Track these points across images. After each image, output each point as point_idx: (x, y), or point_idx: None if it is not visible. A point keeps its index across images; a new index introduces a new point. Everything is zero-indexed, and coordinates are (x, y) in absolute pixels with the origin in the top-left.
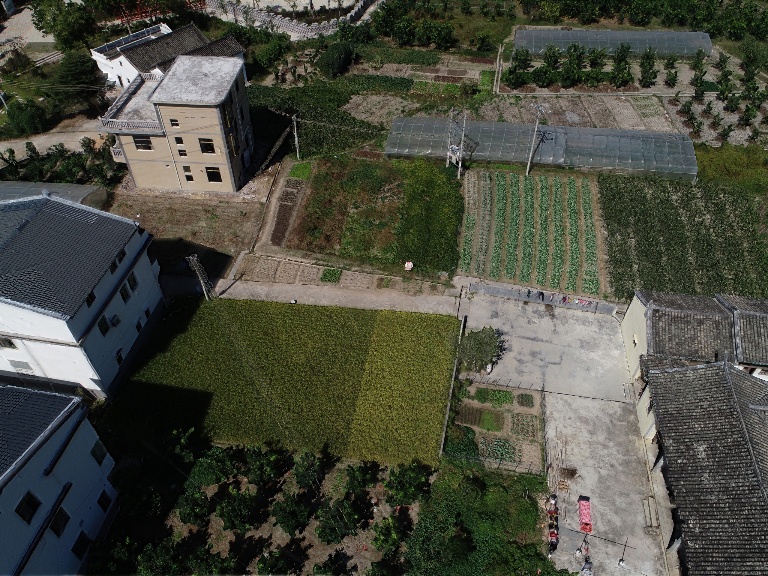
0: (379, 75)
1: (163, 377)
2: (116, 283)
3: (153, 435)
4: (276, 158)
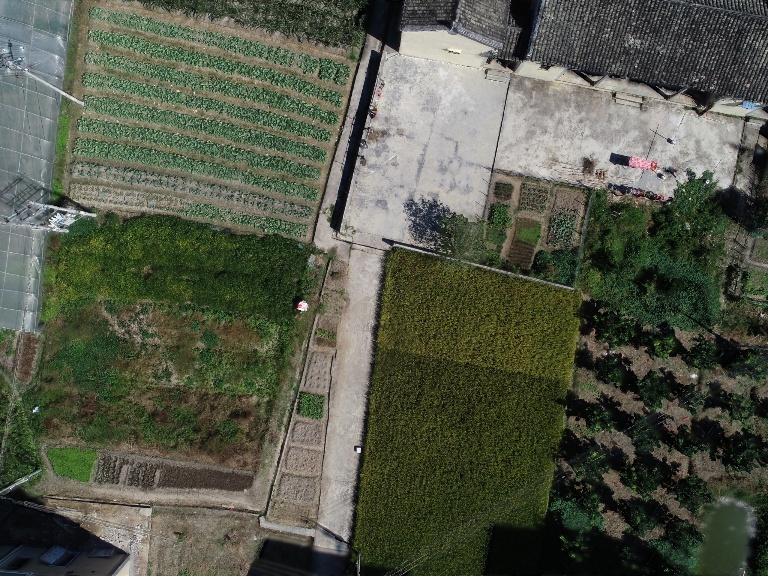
0: None
1: None
2: None
3: (557, 574)
4: None
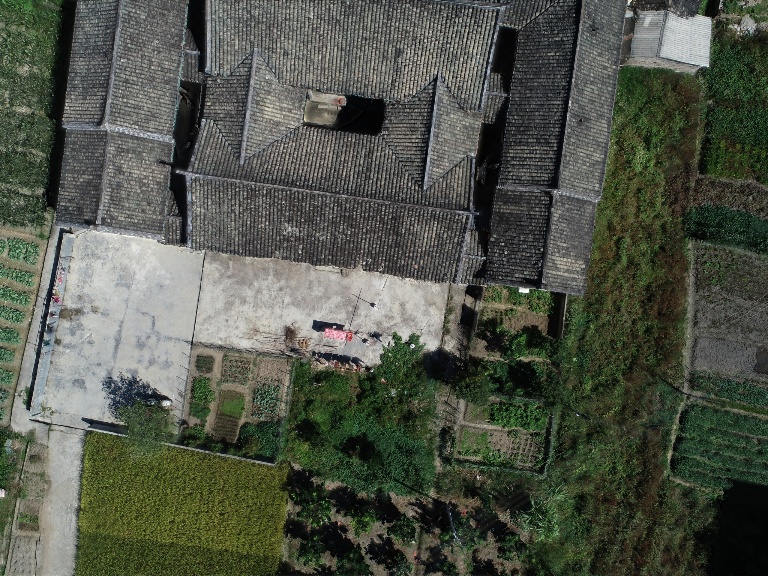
0: None
1: None
2: None
3: None
4: None
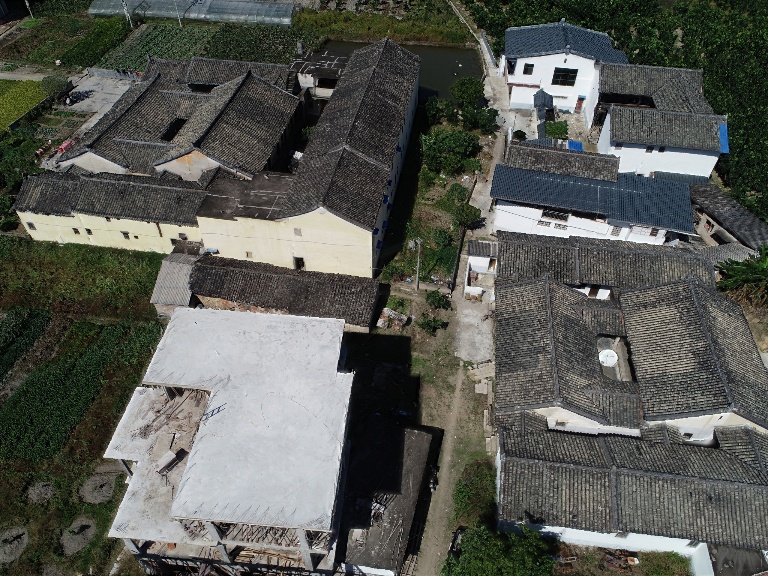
0: None
1: None
2: None
3: None
4: (18, 18)
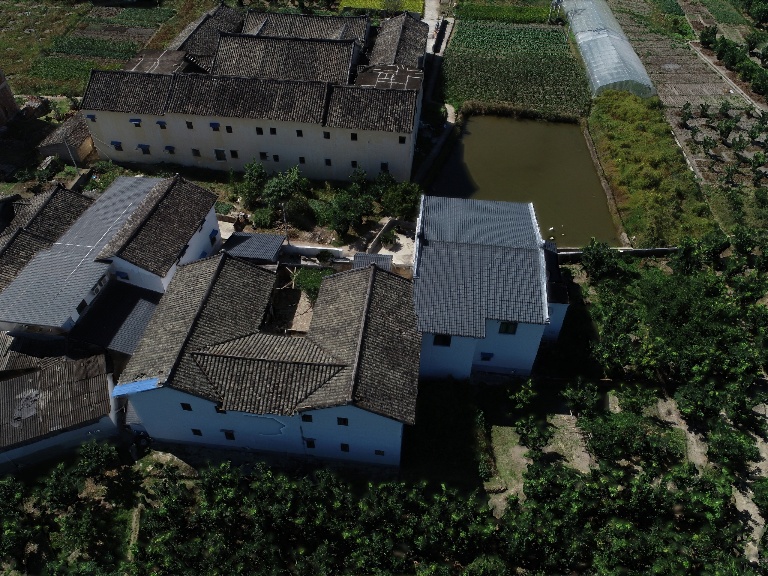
0: (682, 5)
1: None
2: None
3: None
4: None
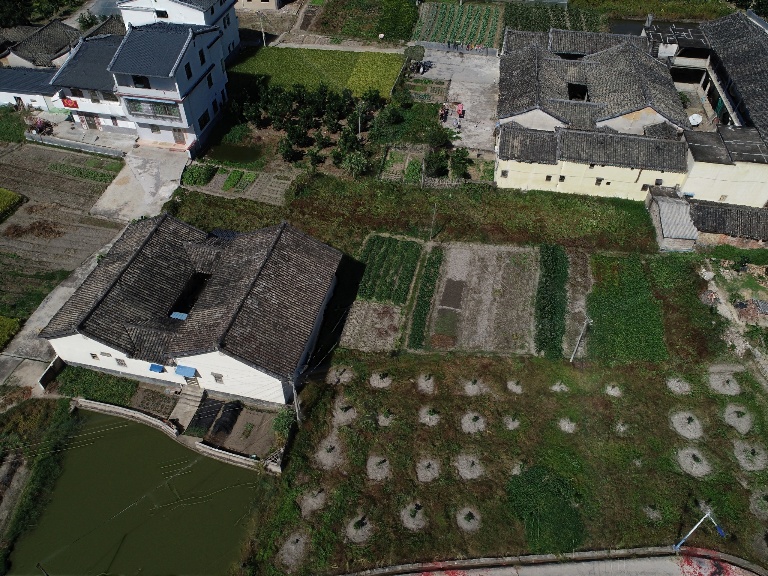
0: None
1: (244, 71)
2: (222, 13)
3: None
4: None
